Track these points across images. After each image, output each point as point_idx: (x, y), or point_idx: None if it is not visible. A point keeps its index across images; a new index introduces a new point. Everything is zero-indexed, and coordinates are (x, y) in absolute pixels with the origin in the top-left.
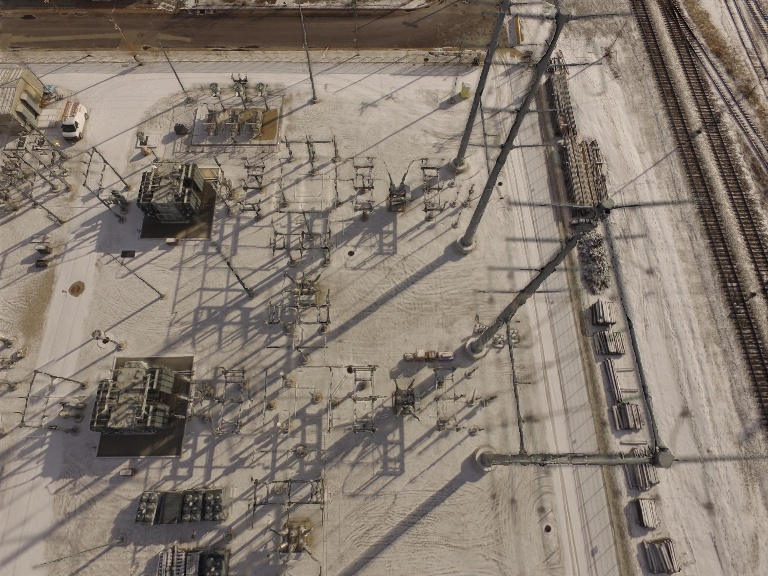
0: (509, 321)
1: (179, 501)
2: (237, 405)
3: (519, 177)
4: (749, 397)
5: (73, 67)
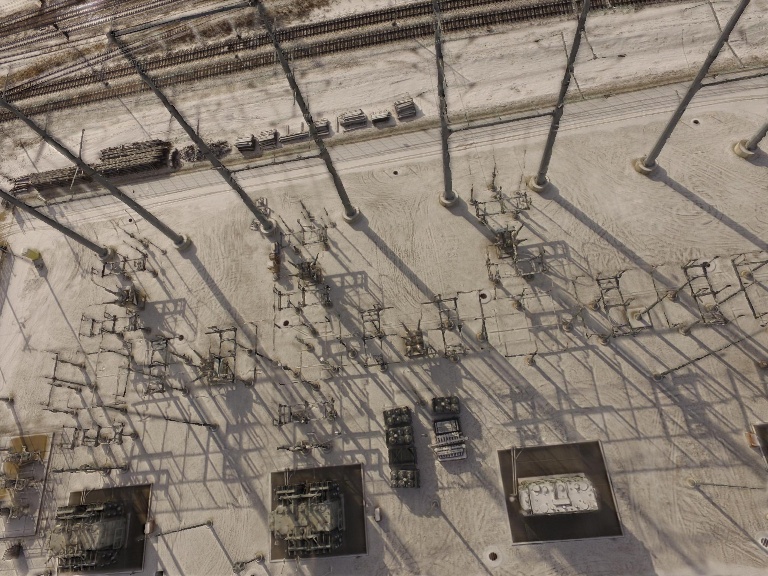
0: (229, 171)
1: (395, 449)
2: None
3: (126, 206)
4: (305, 62)
5: None
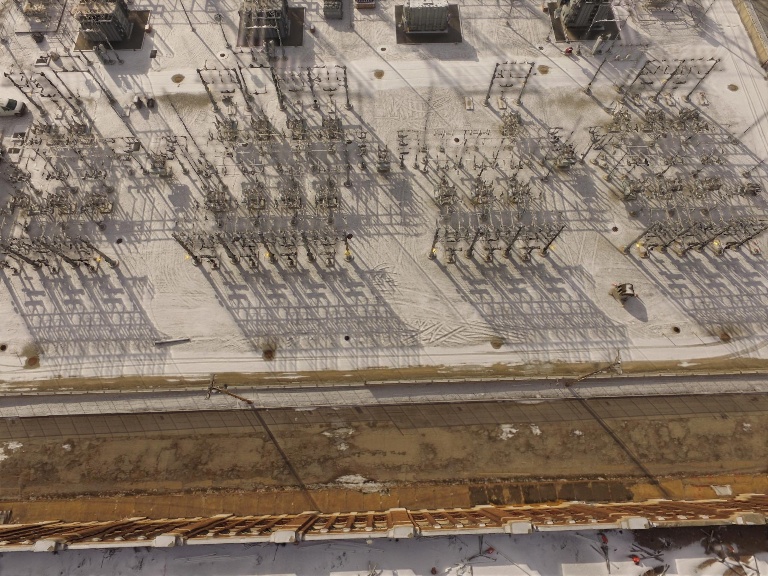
0: None
1: None
2: None
3: None
4: None
5: None
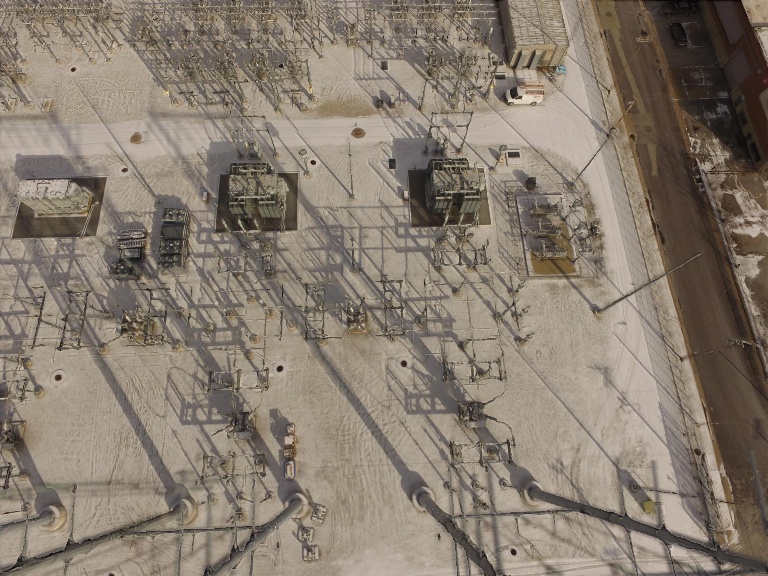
0: None
1: (176, 236)
2: None
3: None
4: None
5: (592, 82)
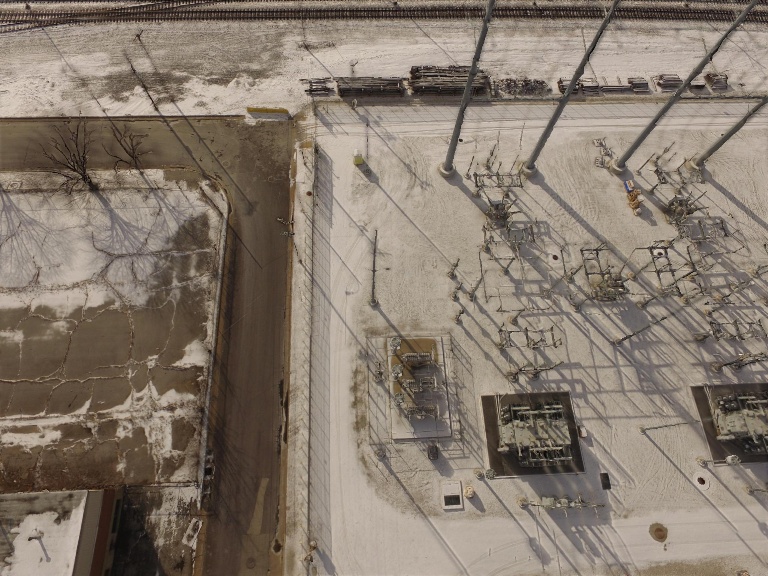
0: None
1: None
2: (717, 342)
3: (451, 126)
4: None
5: None
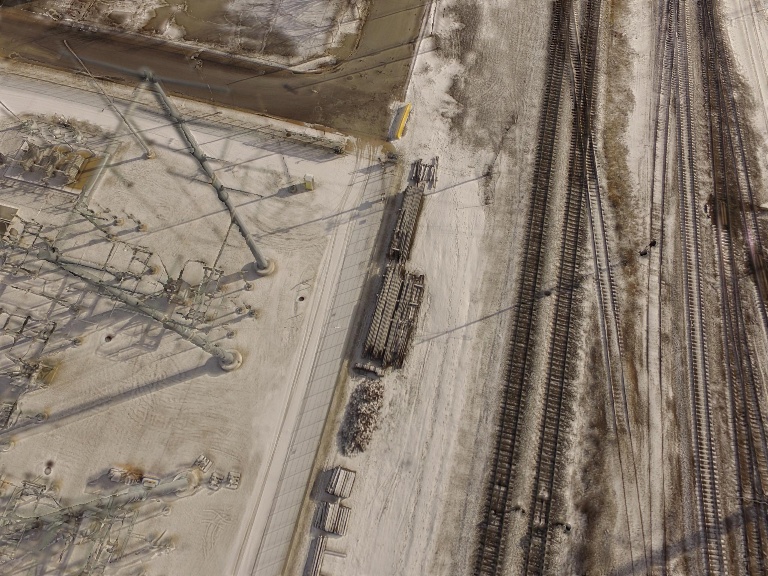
0: (118, 510)
1: None
2: None
3: (325, 296)
4: None
5: None
